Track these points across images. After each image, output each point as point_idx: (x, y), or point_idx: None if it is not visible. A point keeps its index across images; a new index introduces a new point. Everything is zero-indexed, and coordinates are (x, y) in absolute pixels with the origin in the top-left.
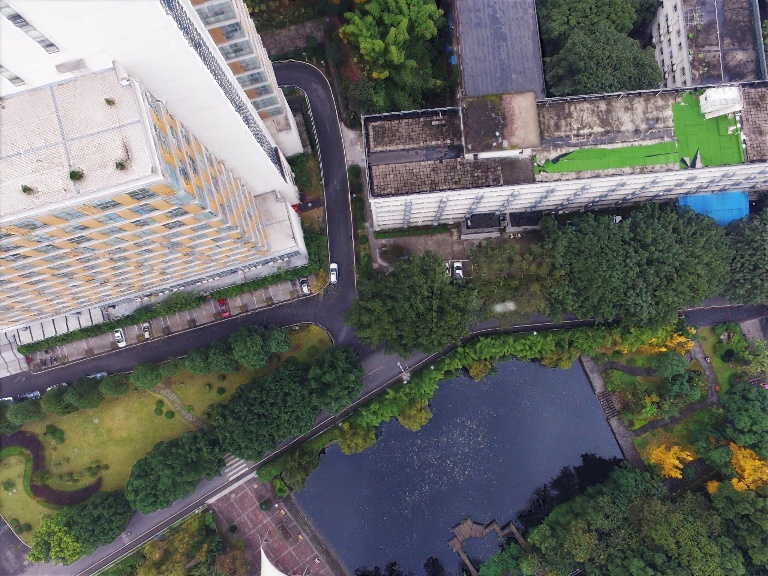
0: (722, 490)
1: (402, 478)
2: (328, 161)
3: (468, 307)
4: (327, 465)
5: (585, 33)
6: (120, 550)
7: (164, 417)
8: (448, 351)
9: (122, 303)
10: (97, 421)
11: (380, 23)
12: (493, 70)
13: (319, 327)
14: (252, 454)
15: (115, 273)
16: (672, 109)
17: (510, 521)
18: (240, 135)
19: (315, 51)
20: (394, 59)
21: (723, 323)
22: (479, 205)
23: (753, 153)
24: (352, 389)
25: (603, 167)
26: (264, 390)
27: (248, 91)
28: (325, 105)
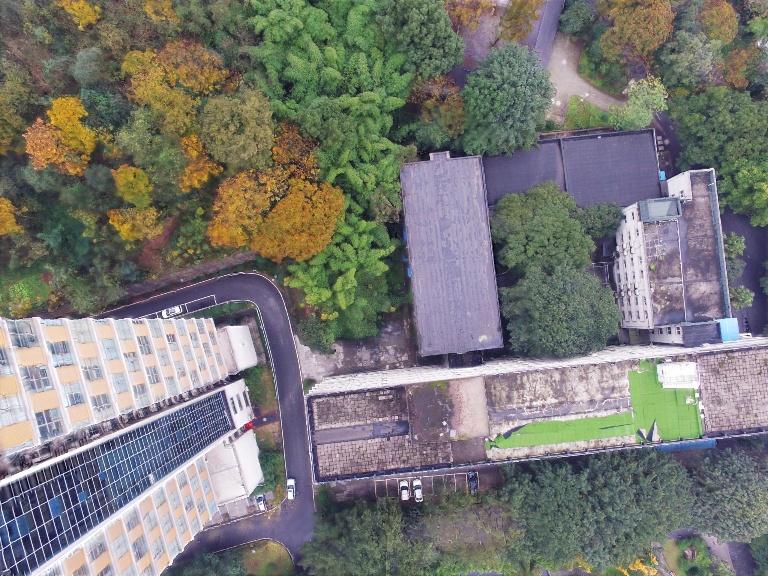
0: None
1: None
2: (282, 375)
3: (423, 557)
4: None
5: (543, 265)
6: None
7: None
8: None
9: None
10: None
11: (328, 264)
12: (447, 308)
13: (277, 543)
14: None
15: None
16: (628, 377)
17: None
18: None
19: (266, 263)
20: (342, 308)
21: (688, 538)
22: None
23: (711, 424)
24: None
25: (557, 441)
26: None
27: None
28: (278, 318)
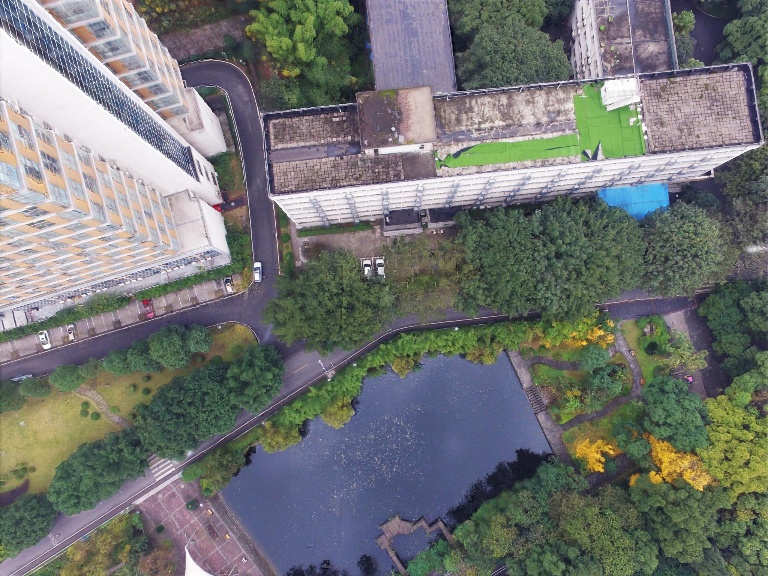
0: (639, 483)
1: (330, 476)
2: (250, 160)
3: (381, 303)
4: (259, 464)
5: (497, 27)
6: (48, 552)
7: (90, 418)
8: (372, 348)
9: (45, 305)
10: (23, 423)
11: (289, 21)
12: (404, 66)
13: (244, 326)
14: (173, 454)
15: (7, 274)
16: (573, 102)
17: (439, 518)
18: (120, 134)
19: (235, 50)
20: (302, 56)
21: (647, 316)
22: (391, 201)
23: (654, 144)
24: (271, 387)
25: (504, 161)
26: (182, 390)
27: (141, 90)
28: (246, 104)
